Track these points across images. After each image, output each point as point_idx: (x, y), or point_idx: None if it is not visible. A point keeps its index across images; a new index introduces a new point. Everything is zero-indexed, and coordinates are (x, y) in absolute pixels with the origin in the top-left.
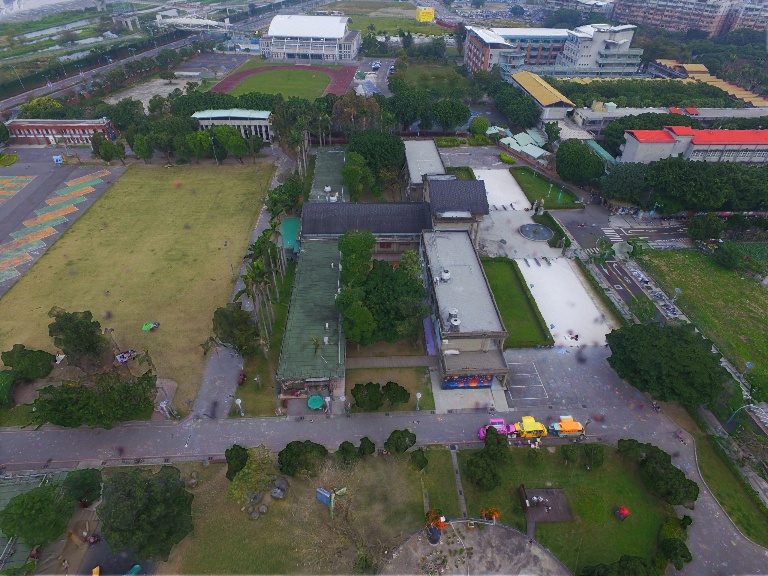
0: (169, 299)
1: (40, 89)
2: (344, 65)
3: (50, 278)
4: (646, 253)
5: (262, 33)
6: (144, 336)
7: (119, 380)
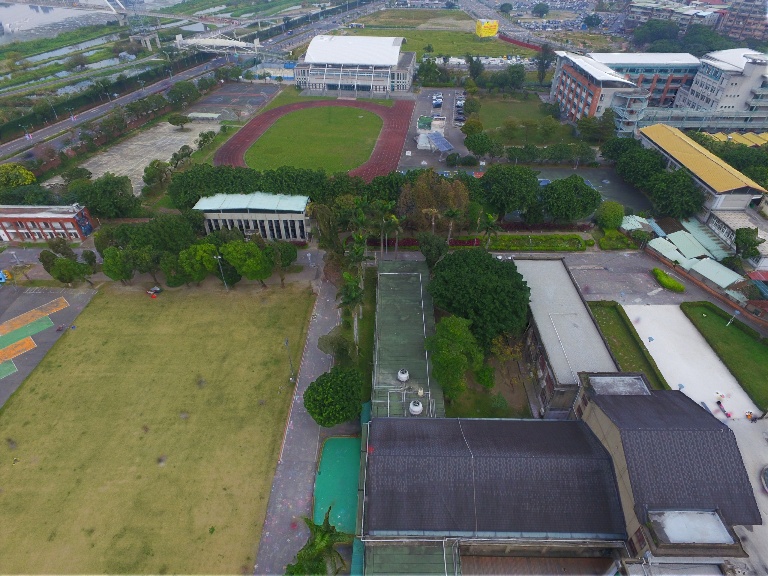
0: None
1: (20, 140)
2: (397, 99)
3: None
4: None
5: None
6: None
7: None
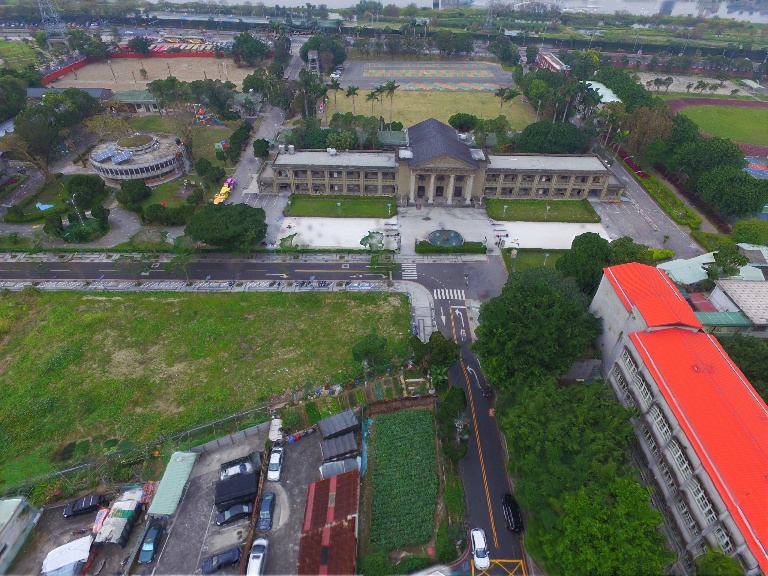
0: None
1: (642, 55)
2: None
3: None
4: (405, 307)
5: None
6: None
7: (281, 93)
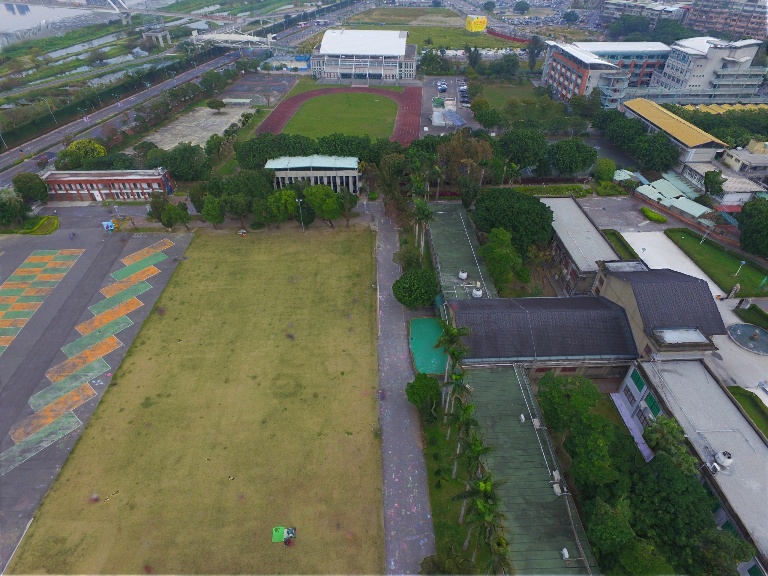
0: (297, 474)
1: (74, 123)
2: (406, 86)
3: (124, 432)
4: None
5: (312, 51)
6: (278, 556)
7: None
